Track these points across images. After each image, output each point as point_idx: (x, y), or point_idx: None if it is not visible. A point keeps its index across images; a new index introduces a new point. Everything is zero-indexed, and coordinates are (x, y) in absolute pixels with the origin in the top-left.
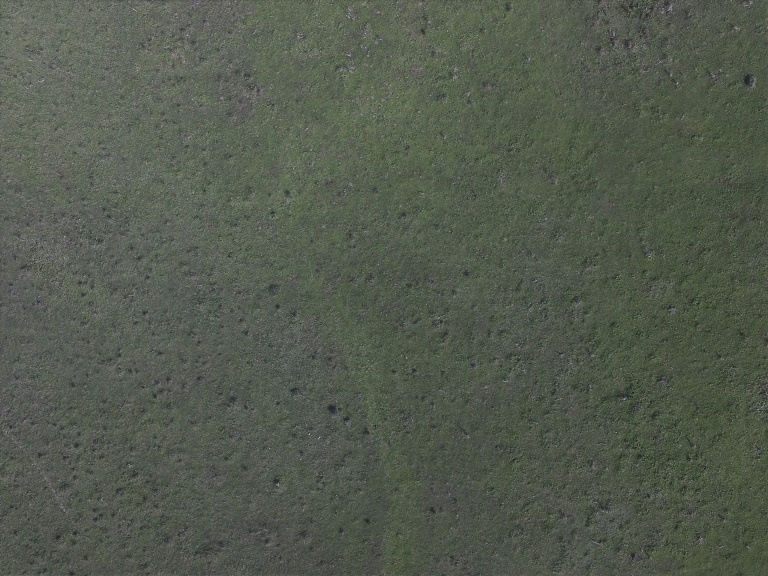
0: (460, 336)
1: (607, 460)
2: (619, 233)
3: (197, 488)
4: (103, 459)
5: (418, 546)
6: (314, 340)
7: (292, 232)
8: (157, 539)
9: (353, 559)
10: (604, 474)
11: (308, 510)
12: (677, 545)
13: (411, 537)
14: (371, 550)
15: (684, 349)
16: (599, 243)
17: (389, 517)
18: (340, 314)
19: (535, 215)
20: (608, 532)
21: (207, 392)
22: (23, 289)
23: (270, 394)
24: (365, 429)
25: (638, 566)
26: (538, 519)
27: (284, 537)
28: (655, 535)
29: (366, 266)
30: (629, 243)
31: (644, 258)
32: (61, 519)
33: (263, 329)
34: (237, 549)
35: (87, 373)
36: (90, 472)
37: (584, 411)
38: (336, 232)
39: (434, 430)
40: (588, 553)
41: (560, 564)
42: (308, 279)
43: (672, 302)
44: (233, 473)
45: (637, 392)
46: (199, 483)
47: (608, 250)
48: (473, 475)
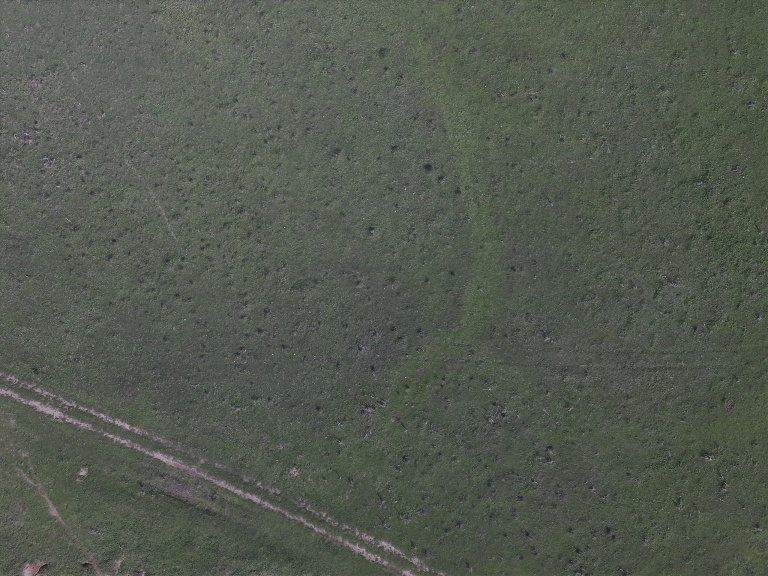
0: (552, 112)
1: (679, 239)
2: (708, 31)
3: (298, 229)
4: (214, 194)
5: (497, 301)
6: (417, 103)
7: (405, 2)
8: (257, 272)
9: (436, 307)
10: (675, 251)
11: (398, 259)
12: (737, 322)
13: (491, 292)
14: (453, 300)
15: (760, 143)
16: (688, 39)
17: (473, 272)
18: (443, 81)
19: (631, 7)
20: (674, 305)
21: (314, 142)
22: (153, 32)
23: (372, 149)
24: (457, 188)
25: (699, 338)
26: (610, 287)
27: (374, 281)
28: (717, 311)
29: (471, 39)
30: (717, 41)
31: (729, 56)
32: (171, 245)
33: (370, 89)
34: (330, 288)
35: (205, 114)
36: (201, 205)
37: (661, 192)
38: (446, 5)
39: (521, 196)
40: (654, 322)
41: (627, 330)
42: (416, 46)
43: (752, 99)
44: (332, 219)
45: (712, 179)
46: (300, 225)
47: (696, 46)
48: (553, 241)
